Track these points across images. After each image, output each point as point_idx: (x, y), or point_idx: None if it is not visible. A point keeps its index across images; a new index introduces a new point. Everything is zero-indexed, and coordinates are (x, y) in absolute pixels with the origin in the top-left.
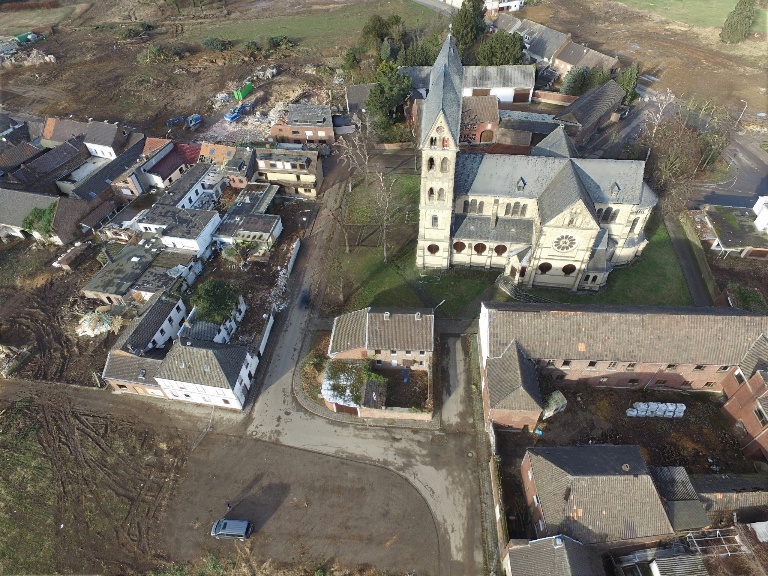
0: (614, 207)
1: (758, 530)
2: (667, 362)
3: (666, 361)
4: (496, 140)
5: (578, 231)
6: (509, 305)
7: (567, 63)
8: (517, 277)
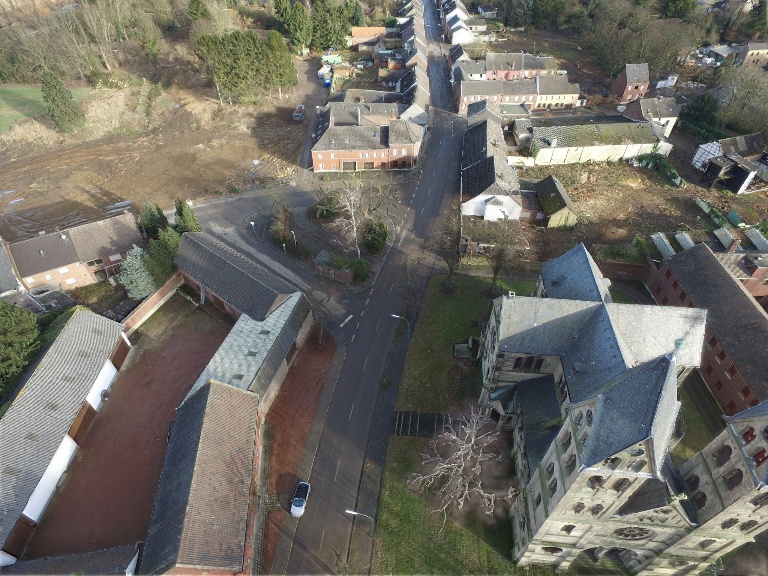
0: None
1: None
2: None
3: None
4: (263, 415)
5: None
6: None
7: (56, 268)
8: None
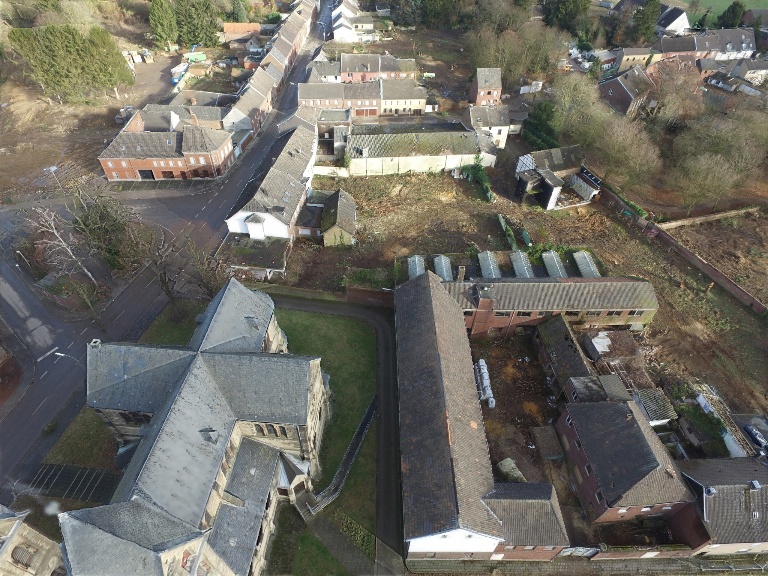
0: (266, 334)
1: (602, 349)
2: (470, 356)
3: (470, 356)
4: None
5: (315, 383)
6: (418, 499)
7: None
8: (310, 484)
